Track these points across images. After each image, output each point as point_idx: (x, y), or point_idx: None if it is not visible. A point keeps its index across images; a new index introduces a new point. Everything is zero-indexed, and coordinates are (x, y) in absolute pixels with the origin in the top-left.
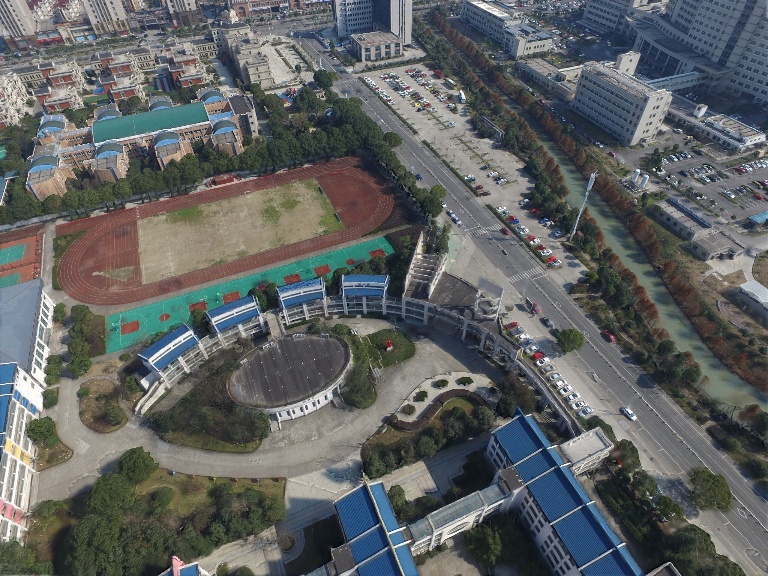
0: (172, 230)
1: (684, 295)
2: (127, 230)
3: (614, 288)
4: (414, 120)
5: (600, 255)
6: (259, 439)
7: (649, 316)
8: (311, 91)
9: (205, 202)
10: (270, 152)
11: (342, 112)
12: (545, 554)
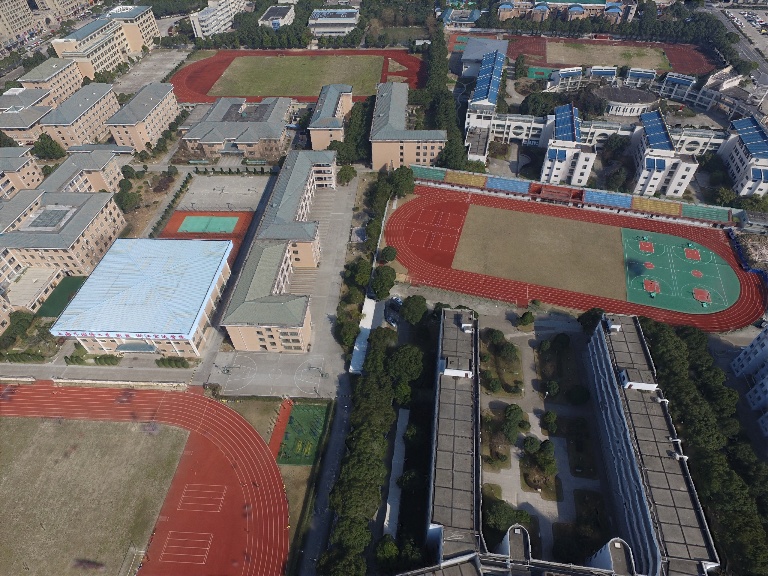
0: (566, 49)
1: None
2: (541, 44)
3: None
4: (755, 38)
5: None
6: (597, 114)
7: None
8: (681, 5)
9: (587, 43)
10: (641, 25)
11: (701, 17)
12: (731, 173)
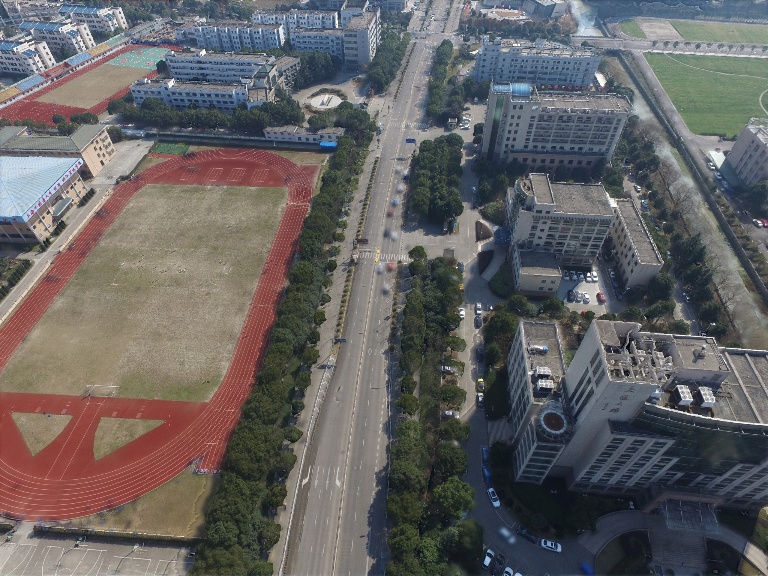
0: None
1: None
2: None
3: (92, 0)
4: None
5: None
6: None
7: (107, 2)
8: None
9: None
10: None
11: None
12: None
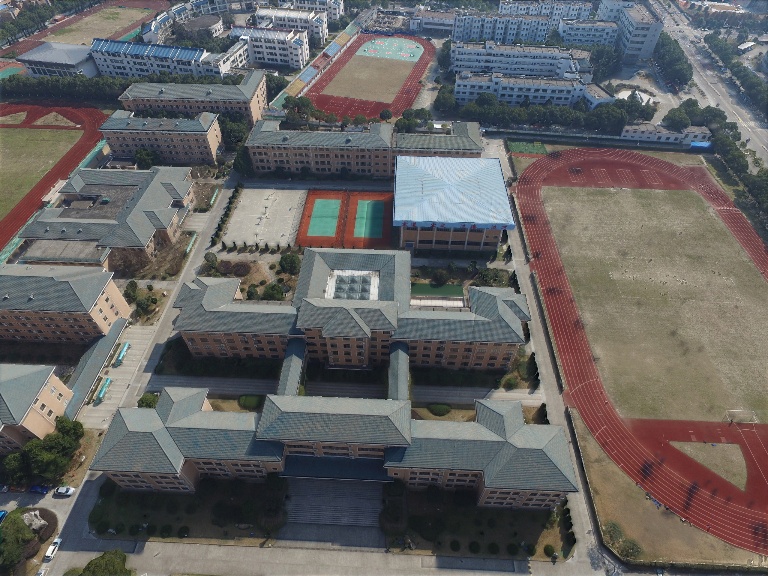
0: (68, 35)
1: None
2: (40, 43)
3: None
4: None
5: None
6: None
7: None
8: None
9: None
10: None
11: None
12: None
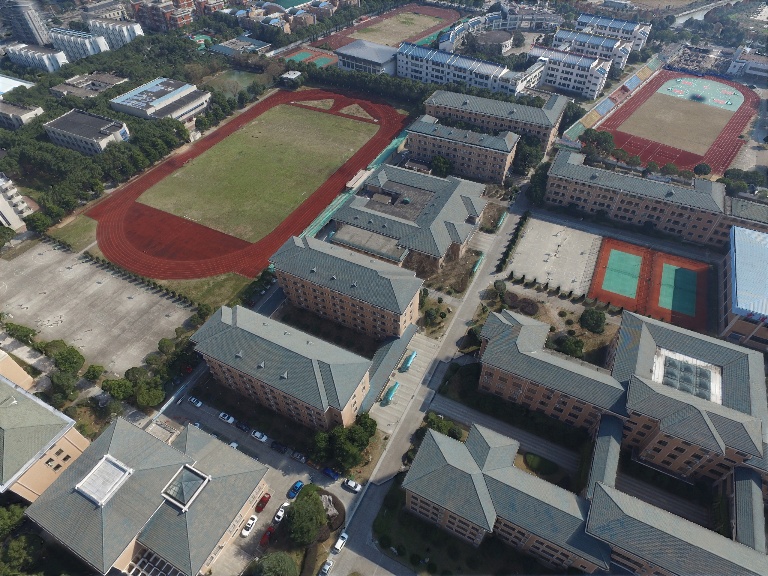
0: (370, 34)
1: (589, 7)
2: None
3: (569, 7)
4: None
5: (553, 5)
6: None
7: (585, 11)
8: None
9: (368, 26)
10: None
11: None
12: None
